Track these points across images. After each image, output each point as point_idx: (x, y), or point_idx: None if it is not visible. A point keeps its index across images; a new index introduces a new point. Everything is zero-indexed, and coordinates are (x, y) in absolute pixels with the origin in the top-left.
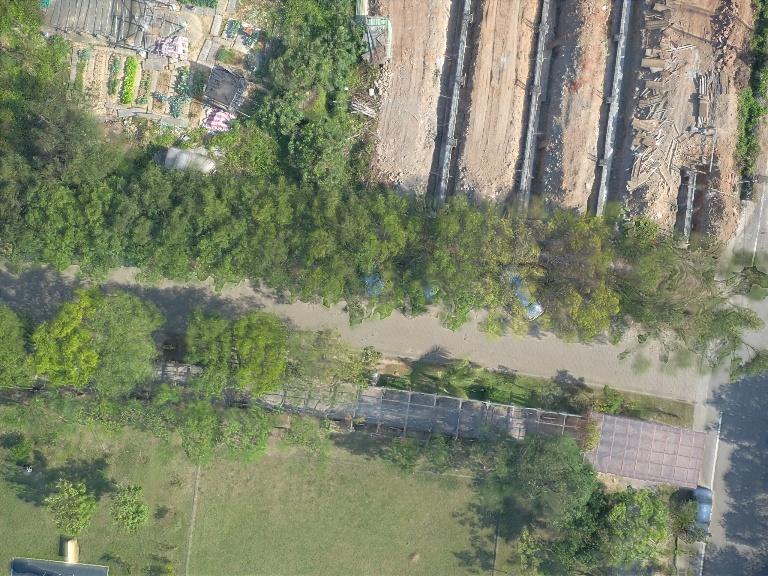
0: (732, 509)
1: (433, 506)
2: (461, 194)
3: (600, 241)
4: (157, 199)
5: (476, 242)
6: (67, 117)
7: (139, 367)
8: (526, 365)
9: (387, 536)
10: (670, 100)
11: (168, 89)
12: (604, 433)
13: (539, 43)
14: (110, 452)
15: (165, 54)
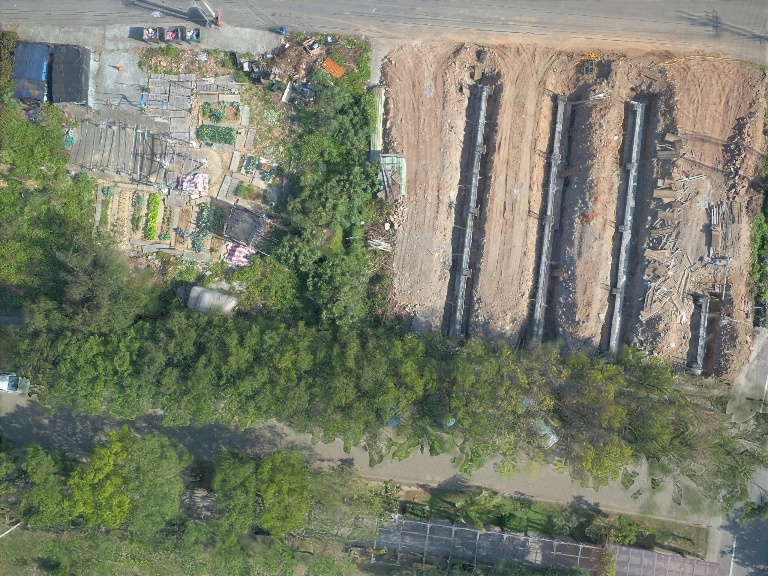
0: None
1: None
2: (476, 325)
3: (613, 389)
4: (182, 346)
5: (491, 395)
6: (94, 263)
7: (168, 509)
8: (542, 491)
9: None
10: (682, 230)
11: (190, 225)
12: (619, 564)
13: (551, 173)
14: (141, 575)
15: (186, 191)
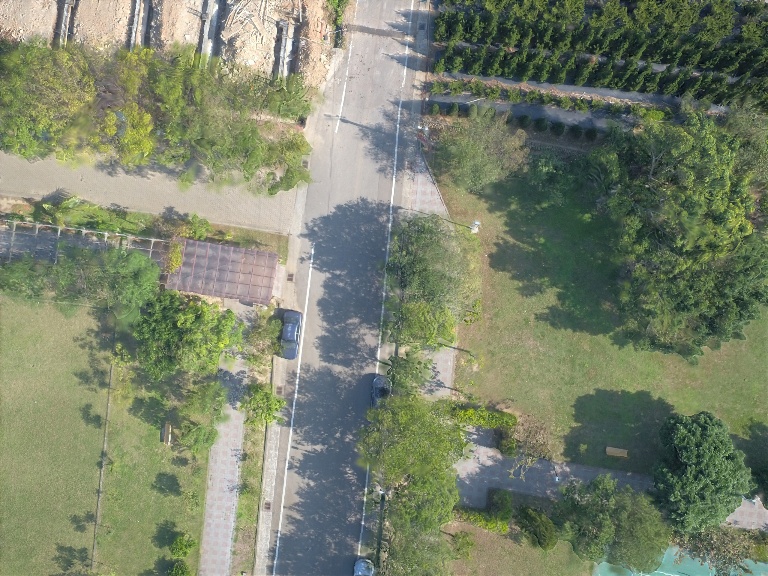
0: (324, 332)
1: (56, 332)
2: (75, 48)
3: (148, 70)
4: None
5: (27, 70)
6: None
7: None
8: (136, 203)
9: (16, 359)
10: None
11: None
12: (186, 255)
13: None
14: None
15: None
